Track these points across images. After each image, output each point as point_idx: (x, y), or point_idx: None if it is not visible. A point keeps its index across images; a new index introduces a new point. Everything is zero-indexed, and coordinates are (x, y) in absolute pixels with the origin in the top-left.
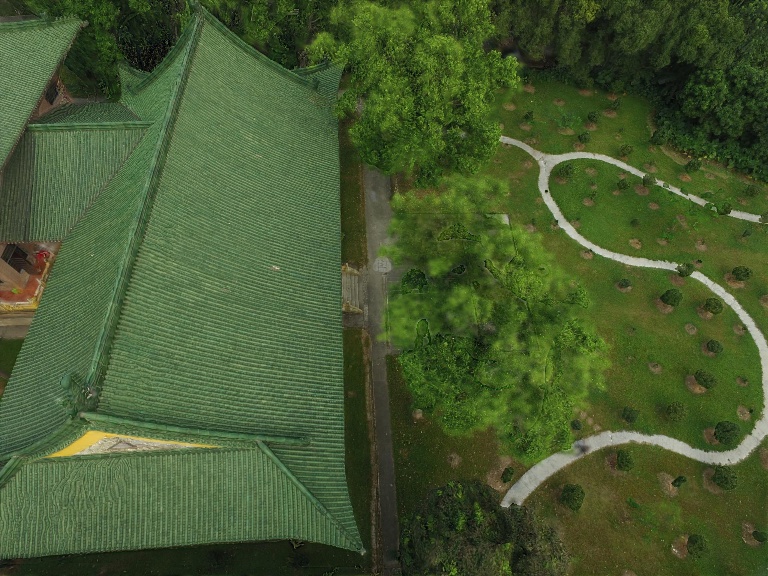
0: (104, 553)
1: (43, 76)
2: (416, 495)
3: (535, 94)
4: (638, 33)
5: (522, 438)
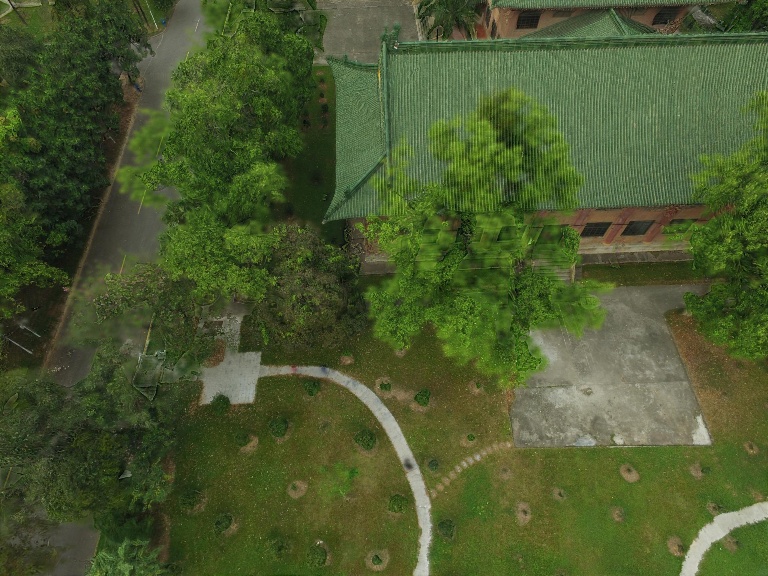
0: None
1: (665, 0)
2: (373, 322)
3: None
4: None
5: None
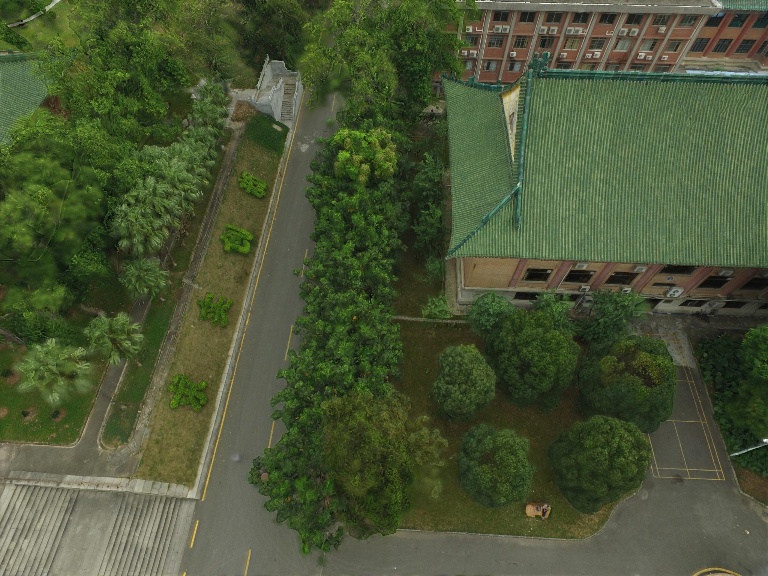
0: (53, 242)
1: None
2: None
3: None
4: None
5: None
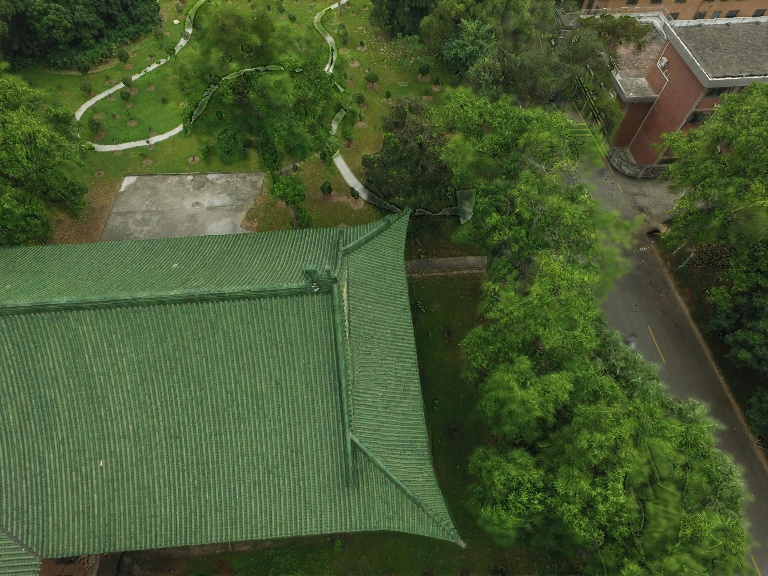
0: None
1: None
2: None
3: None
4: None
5: (347, 112)
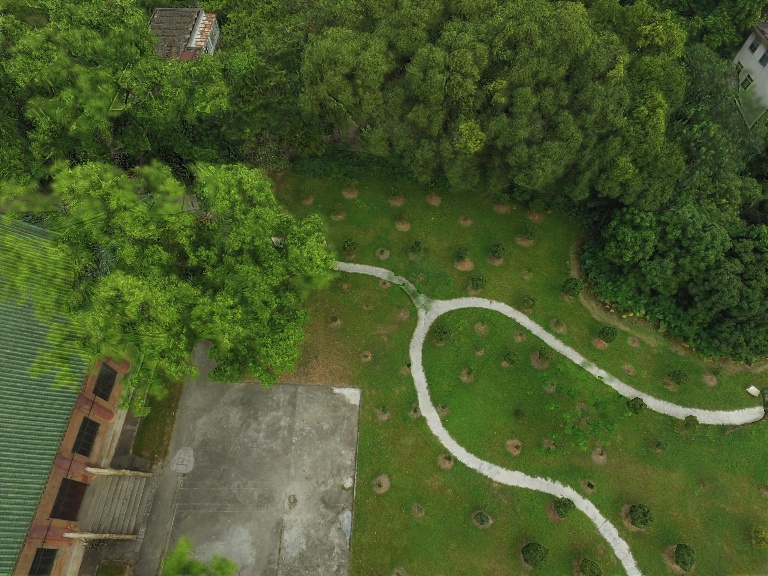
0: None
1: None
2: None
3: (439, 208)
4: (533, 171)
5: None
